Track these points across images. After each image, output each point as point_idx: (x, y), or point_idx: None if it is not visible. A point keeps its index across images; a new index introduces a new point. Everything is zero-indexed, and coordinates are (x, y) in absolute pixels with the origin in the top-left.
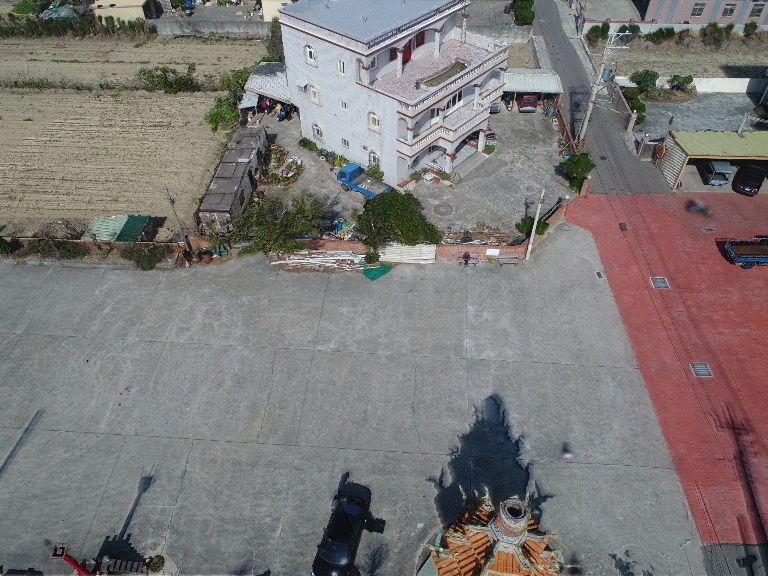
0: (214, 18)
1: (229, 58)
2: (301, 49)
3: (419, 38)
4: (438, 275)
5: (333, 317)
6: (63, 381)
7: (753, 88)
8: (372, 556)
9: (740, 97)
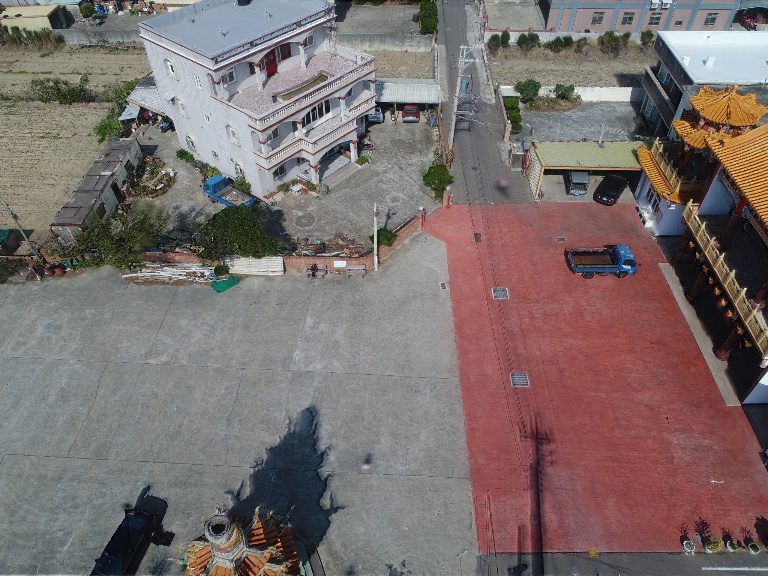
0: (124, 27)
1: (132, 68)
2: (163, 63)
3: (285, 51)
4: (285, 287)
5: (171, 330)
6: None
7: (636, 97)
8: (154, 569)
9: (623, 106)
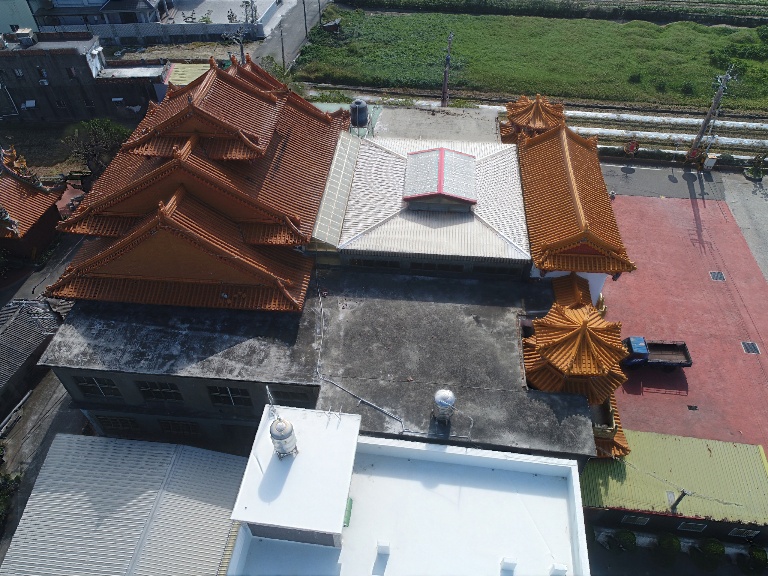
0: None
1: None
2: None
3: None
4: None
5: None
6: None
7: None
8: None
9: None
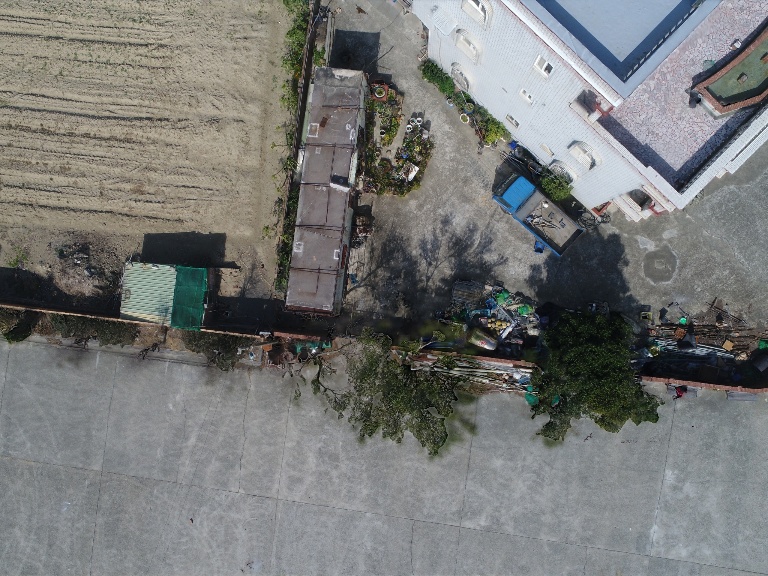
0: None
1: None
2: None
3: None
4: None
5: (484, 475)
6: (173, 547)
7: None
8: None
9: None
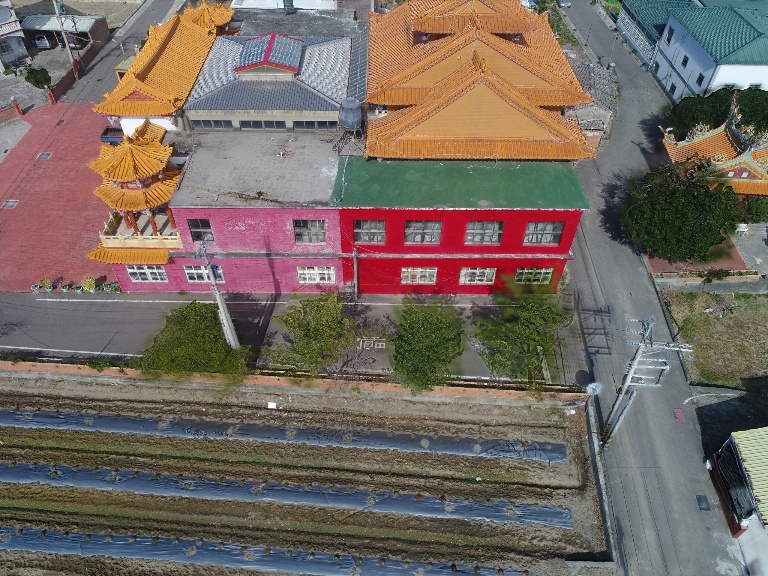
0: None
1: None
2: None
3: None
4: None
5: None
6: None
7: None
8: None
9: None
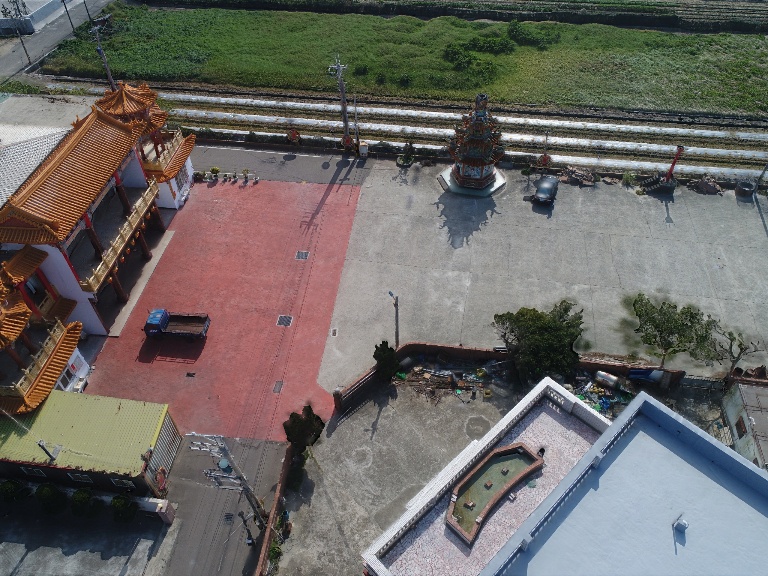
0: None
1: None
2: None
3: None
4: (488, 343)
5: None
6: None
7: None
8: (529, 190)
9: None
